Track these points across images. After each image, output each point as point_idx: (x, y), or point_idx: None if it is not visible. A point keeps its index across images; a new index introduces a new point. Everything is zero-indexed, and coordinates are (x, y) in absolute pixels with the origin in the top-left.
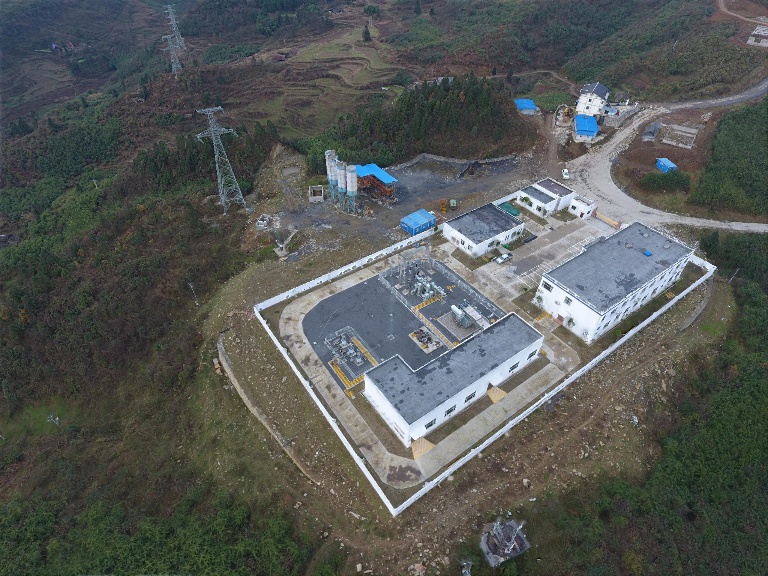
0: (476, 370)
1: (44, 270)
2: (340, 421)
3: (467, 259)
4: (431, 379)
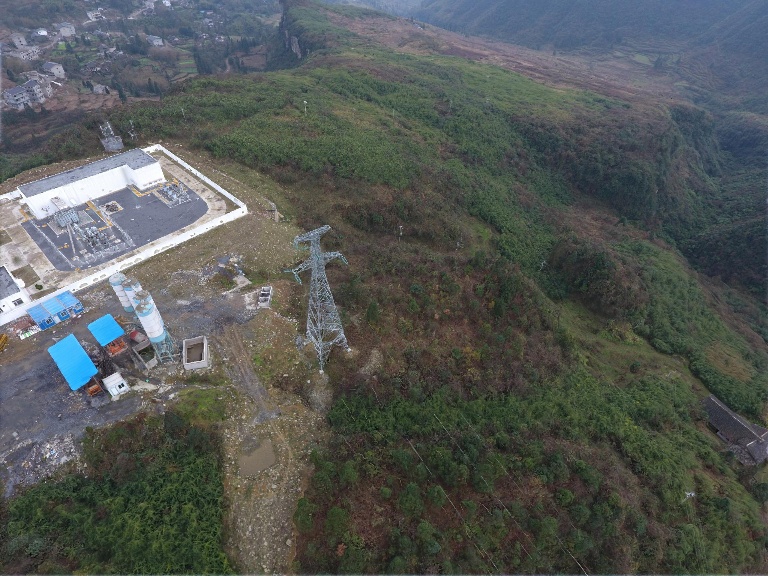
0: (84, 170)
1: (494, 271)
2: (183, 170)
3: (24, 276)
4: (117, 164)
